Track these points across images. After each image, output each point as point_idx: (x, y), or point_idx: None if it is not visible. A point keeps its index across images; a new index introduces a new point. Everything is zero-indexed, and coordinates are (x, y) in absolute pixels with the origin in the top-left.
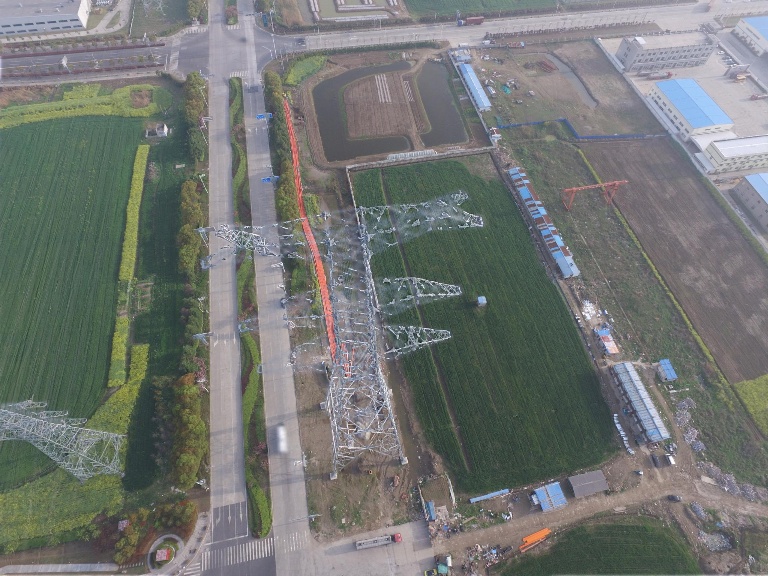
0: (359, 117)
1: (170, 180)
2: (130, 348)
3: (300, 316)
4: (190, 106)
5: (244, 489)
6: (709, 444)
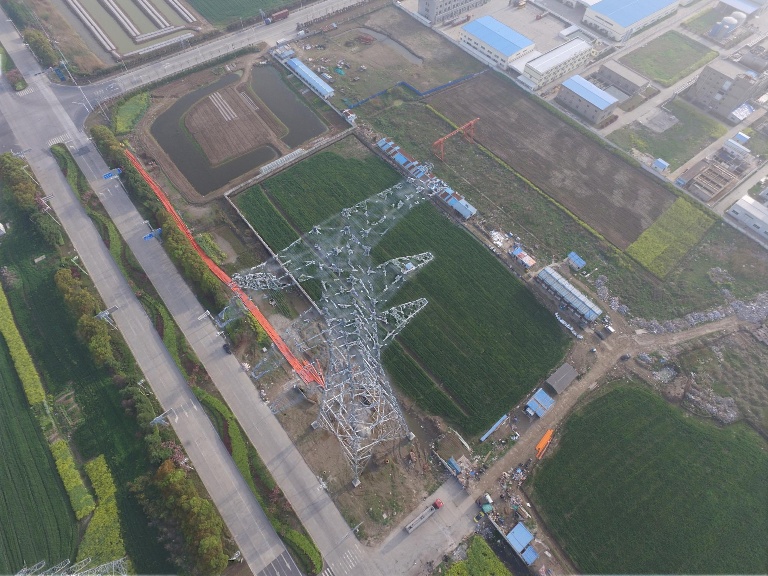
0: (213, 142)
1: (35, 278)
2: (82, 469)
3: (250, 354)
4: (19, 191)
5: (278, 540)
6: (629, 304)
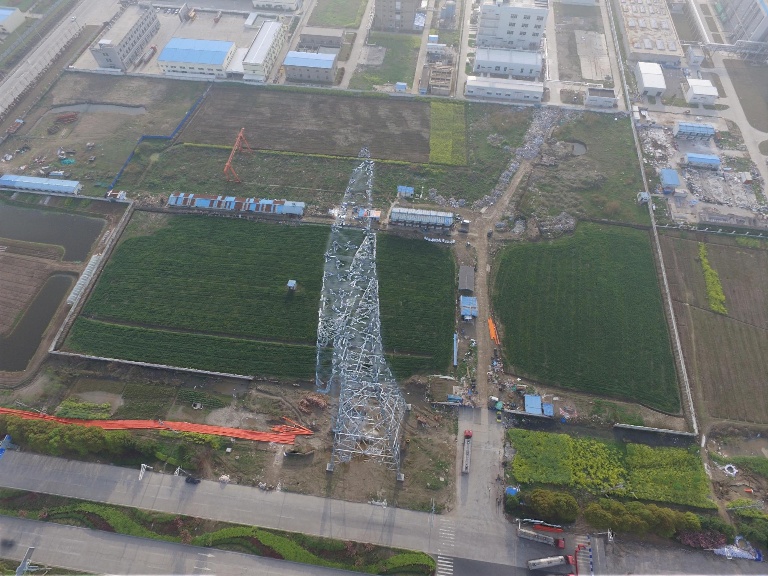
0: None
1: None
2: None
3: (218, 465)
4: None
5: None
6: (462, 196)
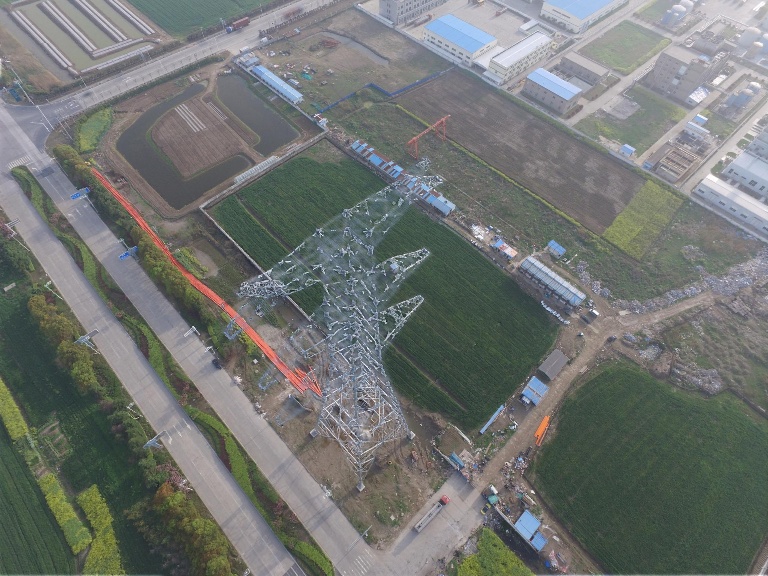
0: (183, 154)
1: (7, 307)
2: (75, 501)
3: (241, 367)
4: None
5: (287, 553)
6: (611, 287)
